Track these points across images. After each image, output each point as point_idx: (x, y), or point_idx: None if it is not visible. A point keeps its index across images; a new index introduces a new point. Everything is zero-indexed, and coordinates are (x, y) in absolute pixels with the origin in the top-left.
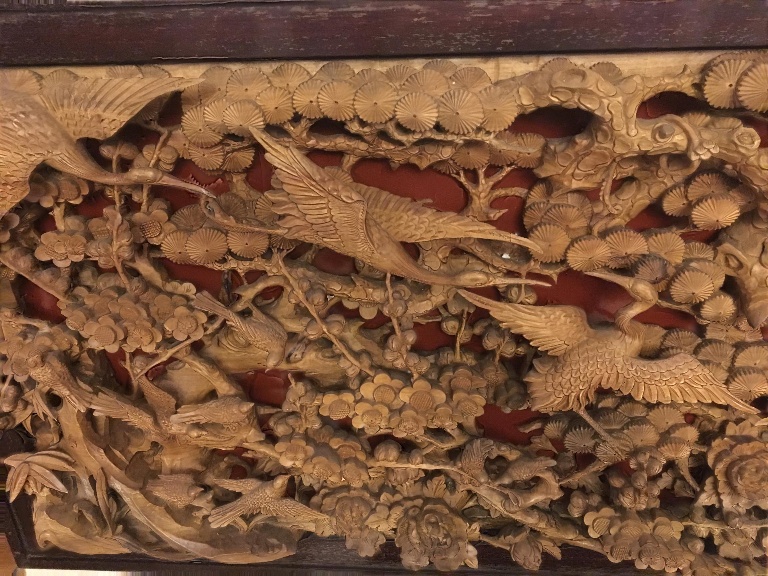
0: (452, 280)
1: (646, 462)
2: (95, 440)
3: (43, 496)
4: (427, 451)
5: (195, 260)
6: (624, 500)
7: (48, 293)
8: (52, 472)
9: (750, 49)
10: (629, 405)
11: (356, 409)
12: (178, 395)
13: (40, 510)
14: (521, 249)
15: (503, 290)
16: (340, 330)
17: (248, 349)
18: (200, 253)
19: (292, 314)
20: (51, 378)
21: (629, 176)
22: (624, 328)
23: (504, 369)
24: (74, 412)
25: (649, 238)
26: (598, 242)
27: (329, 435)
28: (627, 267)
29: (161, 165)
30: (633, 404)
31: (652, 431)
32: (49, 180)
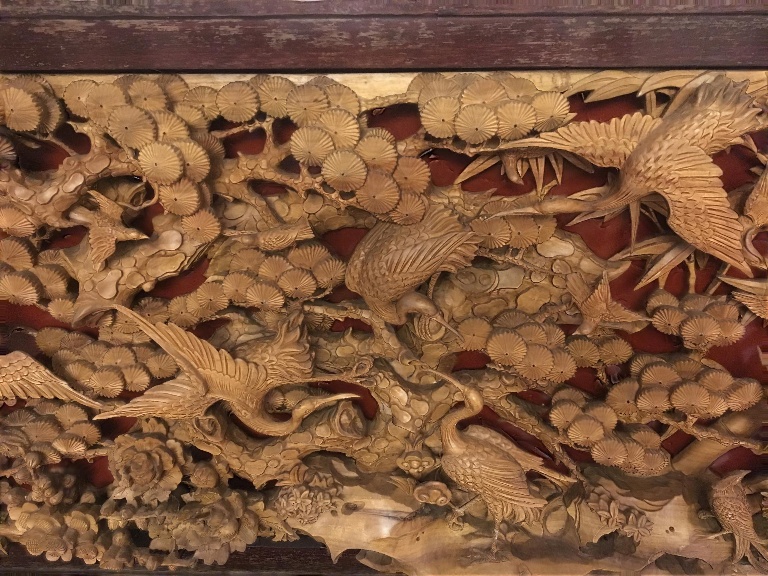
0: None
1: (24, 456)
2: None
3: None
4: None
5: None
6: (32, 494)
7: None
8: None
9: (24, 73)
10: (43, 404)
11: None
12: None
13: None
14: None
15: None
16: None
17: None
18: None
19: None
20: None
21: None
22: None
23: None
24: None
25: None
26: None
27: None
28: None
29: None
30: (46, 403)
31: (48, 428)
32: None
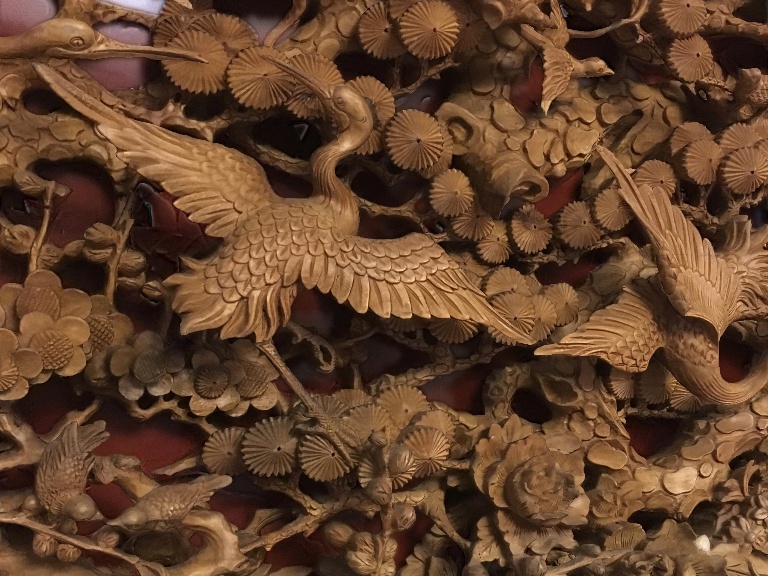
0: (26, 35)
1: (387, 451)
2: None
3: None
4: None
5: None
6: (357, 556)
7: None
8: None
9: None
10: (343, 393)
11: None
12: None
13: None
14: (150, 99)
15: (120, 177)
16: None
17: None
18: None
19: None
20: None
21: (307, 3)
22: (328, 179)
23: (124, 314)
24: None
25: (345, 83)
26: (275, 53)
27: None
28: (319, 118)
29: None
30: (349, 390)
31: (386, 418)
32: None
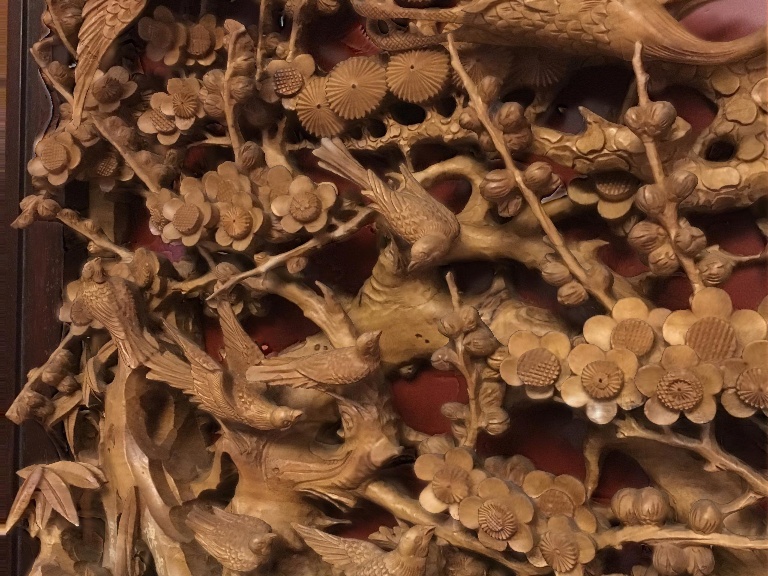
0: (765, 28)
1: None
2: (142, 441)
3: (49, 544)
4: (732, 507)
5: (337, 112)
6: None
7: None
8: (69, 487)
9: None
10: None
11: (571, 360)
12: (283, 390)
13: (36, 565)
14: None
15: None
16: (544, 169)
17: (401, 293)
18: (344, 94)
19: (479, 224)
20: (106, 304)
21: None
22: None
23: None
24: (124, 378)
25: None
26: None
27: (525, 473)
28: None
29: (321, 0)
30: None
31: None
32: (180, 22)
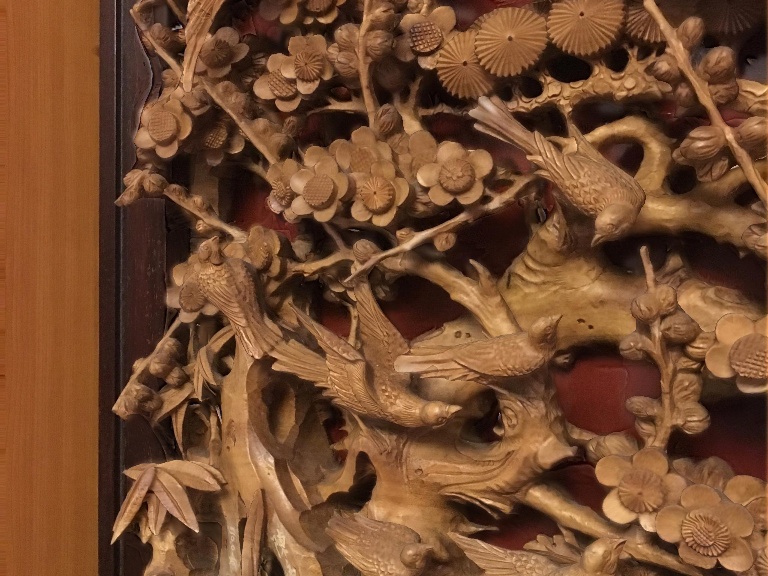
0: None
1: None
2: (266, 439)
3: (162, 551)
4: None
5: (488, 68)
6: None
7: (263, 210)
8: (185, 489)
9: None
10: None
11: None
12: (421, 382)
13: (150, 574)
14: None
15: None
16: (766, 124)
17: (562, 273)
18: (498, 47)
19: (657, 193)
20: (225, 288)
21: None
22: None
23: None
24: (245, 369)
25: None
26: None
27: (724, 477)
28: None
29: None
30: None
31: None
32: None
